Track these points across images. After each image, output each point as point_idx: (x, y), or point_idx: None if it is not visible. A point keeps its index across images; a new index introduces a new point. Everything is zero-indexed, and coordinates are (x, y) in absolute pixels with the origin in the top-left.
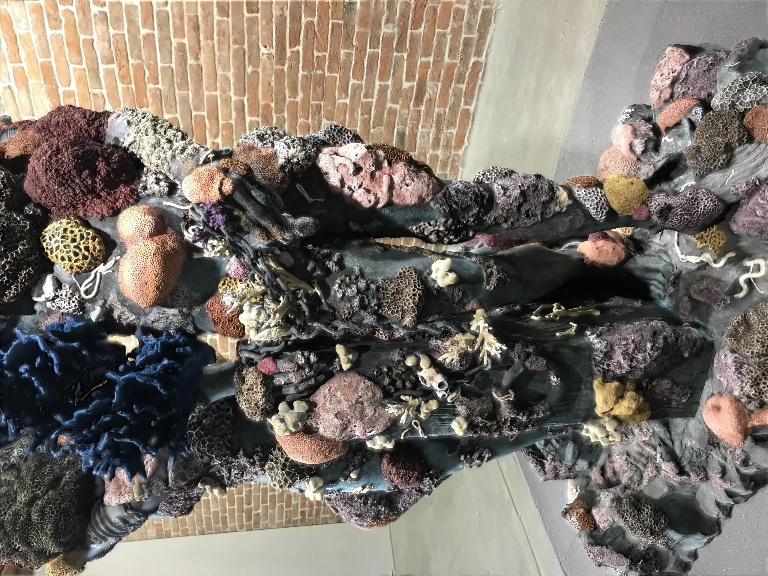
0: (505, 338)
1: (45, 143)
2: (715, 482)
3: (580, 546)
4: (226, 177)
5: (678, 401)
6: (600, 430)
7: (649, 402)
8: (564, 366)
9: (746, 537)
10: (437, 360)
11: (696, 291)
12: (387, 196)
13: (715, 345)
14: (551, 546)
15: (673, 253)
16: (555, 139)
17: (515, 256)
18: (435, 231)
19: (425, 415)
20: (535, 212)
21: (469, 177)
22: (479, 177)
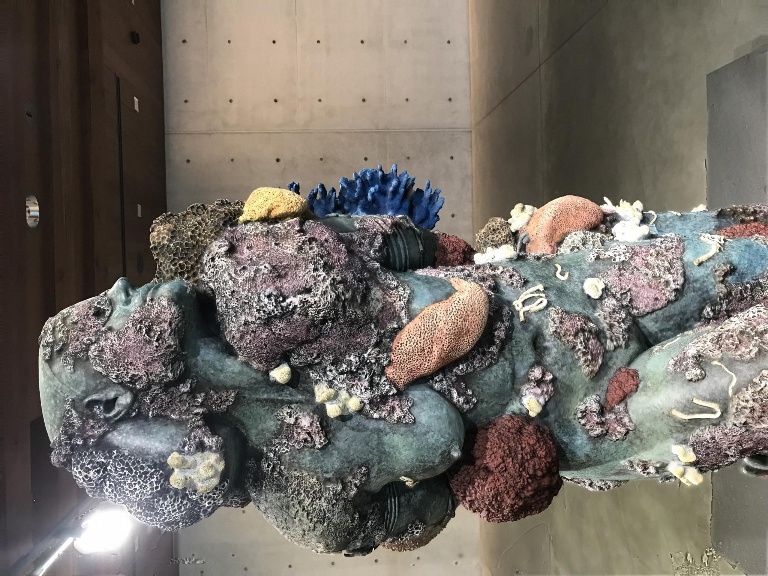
0: None
1: None
2: None
3: None
4: None
5: None
6: None
7: None
8: None
9: None
10: None
11: None
12: None
13: None
14: None
15: None
16: None
17: None
18: None
19: None
20: None
21: None
22: None
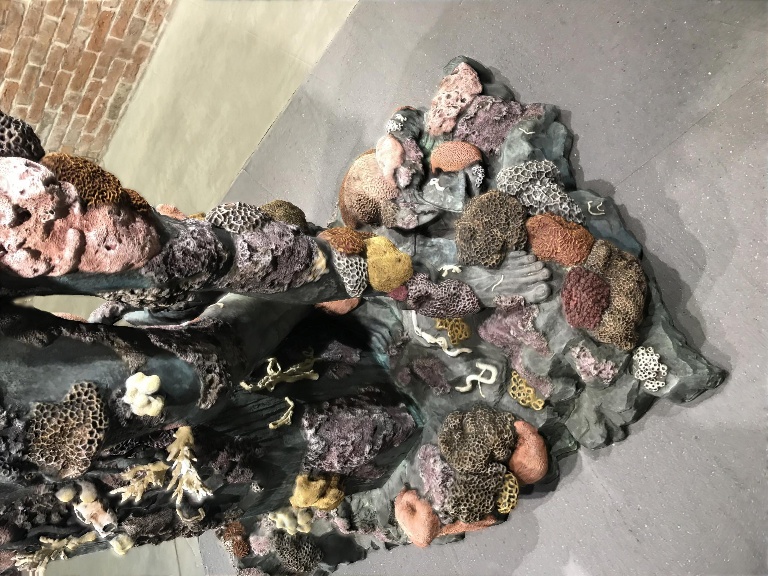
0: (208, 442)
1: None
2: (379, 535)
3: None
4: None
5: (372, 479)
6: (290, 522)
7: (346, 485)
8: (271, 468)
9: (388, 571)
10: (107, 486)
11: (419, 366)
12: (69, 264)
13: (424, 433)
14: None
15: (407, 315)
16: (291, 53)
17: (241, 323)
18: (138, 299)
19: (74, 545)
20: (282, 281)
21: (173, 36)
22: (219, 218)
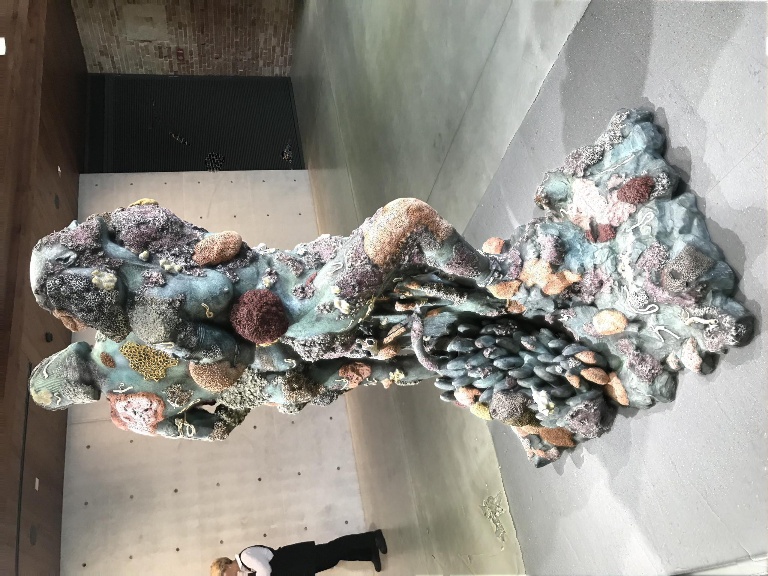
0: None
1: None
2: None
3: (761, 121)
4: None
5: None
6: None
7: None
8: None
9: None
10: None
11: None
12: None
13: None
14: None
15: None
16: None
17: None
18: None
19: None
20: None
21: None
22: None
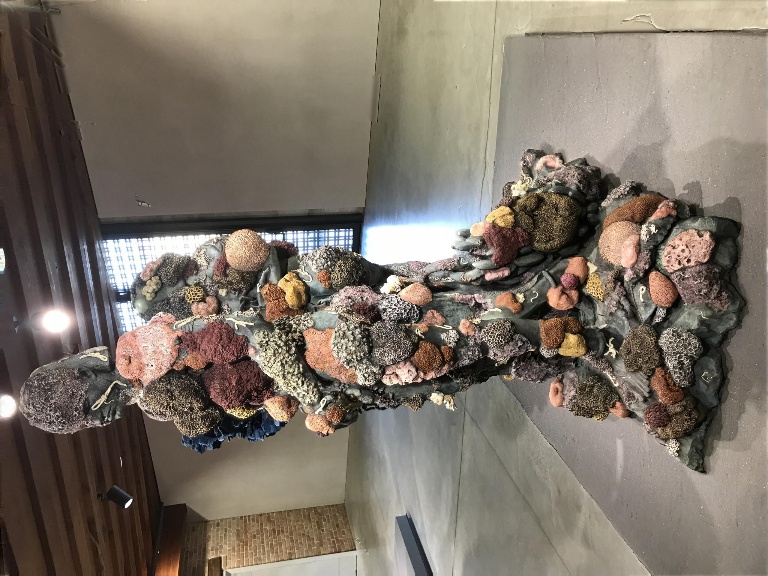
0: None
1: (219, 387)
2: None
3: None
4: (330, 425)
5: None
6: None
7: None
8: None
9: None
10: None
11: None
12: None
13: None
14: (491, 195)
15: None
16: None
17: None
18: None
19: None
20: None
21: None
22: (485, 341)
